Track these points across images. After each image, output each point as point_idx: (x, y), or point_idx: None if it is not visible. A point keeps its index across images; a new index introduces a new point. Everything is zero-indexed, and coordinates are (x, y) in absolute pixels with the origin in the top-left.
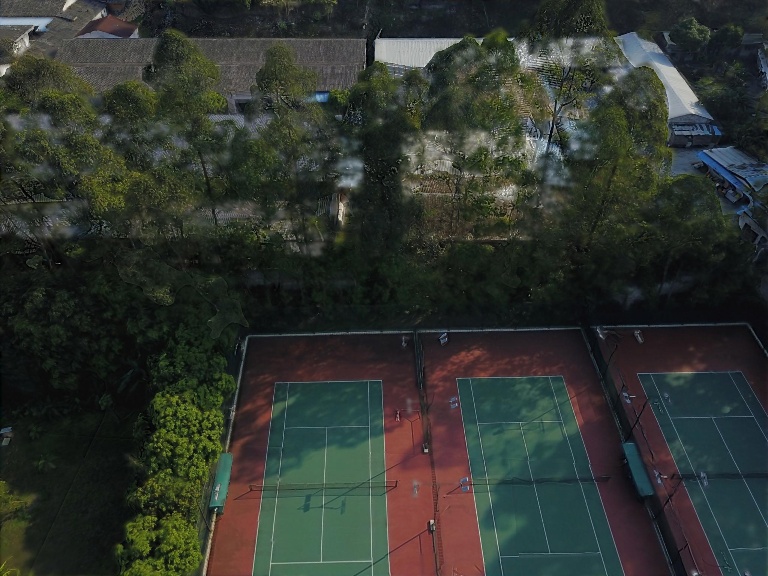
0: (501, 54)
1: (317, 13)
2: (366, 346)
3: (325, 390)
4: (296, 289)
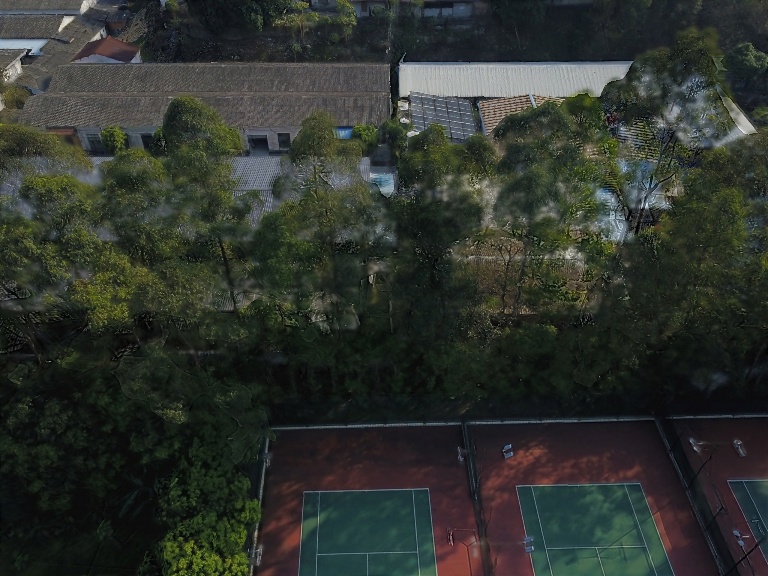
0: (585, 120)
1: (335, 35)
2: (407, 442)
3: (363, 502)
4: (326, 376)
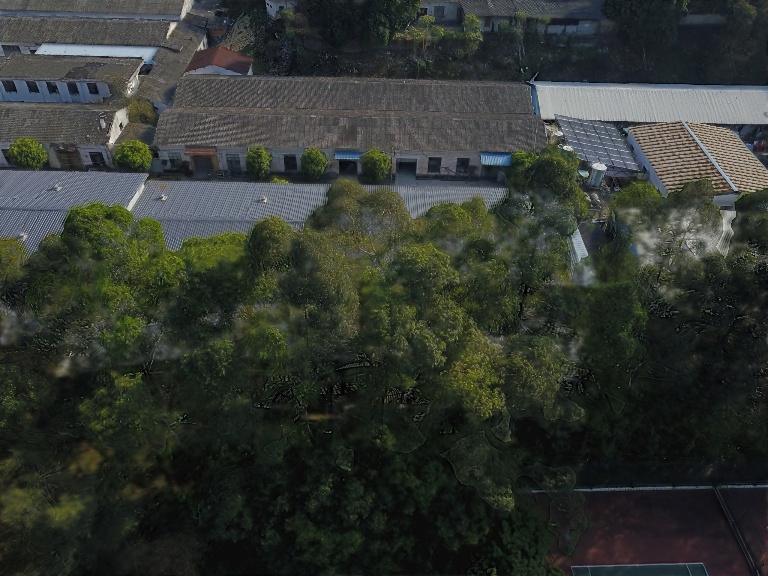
0: None
1: (460, 51)
2: (663, 509)
3: None
4: (577, 437)
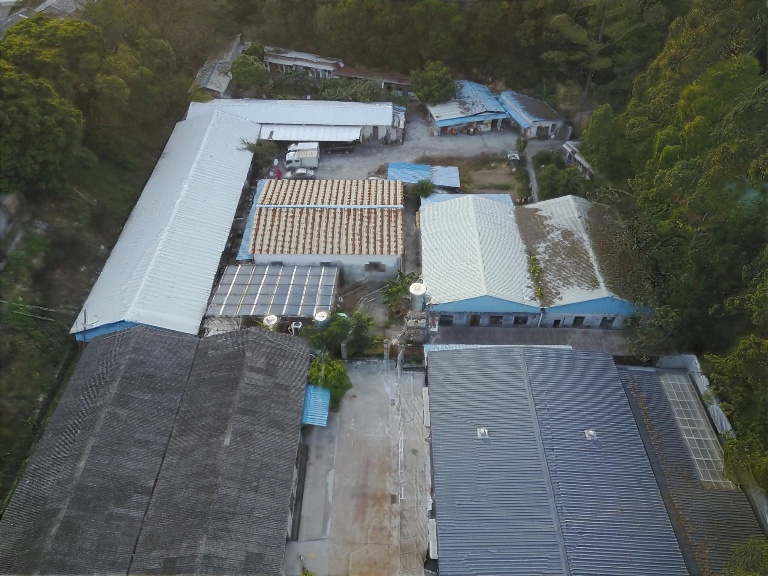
0: None
1: None
2: None
3: None
4: None
